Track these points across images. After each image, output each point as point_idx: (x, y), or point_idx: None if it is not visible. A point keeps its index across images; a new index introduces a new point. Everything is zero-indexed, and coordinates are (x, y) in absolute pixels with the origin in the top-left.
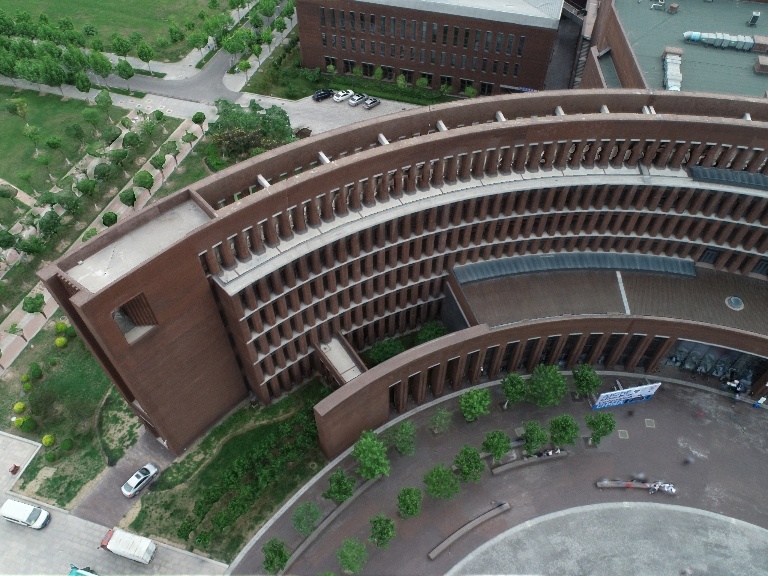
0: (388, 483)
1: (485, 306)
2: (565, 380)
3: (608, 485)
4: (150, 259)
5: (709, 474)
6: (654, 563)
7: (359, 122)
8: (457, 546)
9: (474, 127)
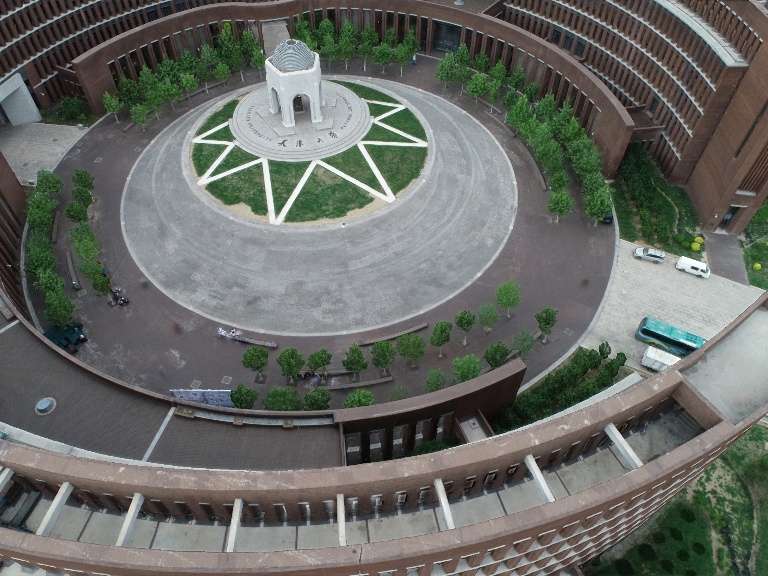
0: (450, 379)
1: (323, 458)
2: (266, 398)
3: (268, 343)
4: (731, 325)
5: (181, 338)
6: (267, 296)
7: (493, 535)
8: (404, 329)
9: (305, 483)
